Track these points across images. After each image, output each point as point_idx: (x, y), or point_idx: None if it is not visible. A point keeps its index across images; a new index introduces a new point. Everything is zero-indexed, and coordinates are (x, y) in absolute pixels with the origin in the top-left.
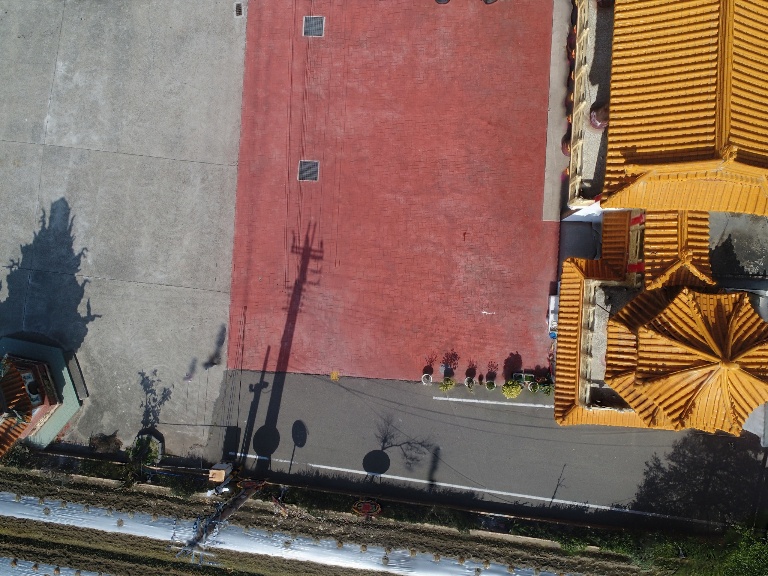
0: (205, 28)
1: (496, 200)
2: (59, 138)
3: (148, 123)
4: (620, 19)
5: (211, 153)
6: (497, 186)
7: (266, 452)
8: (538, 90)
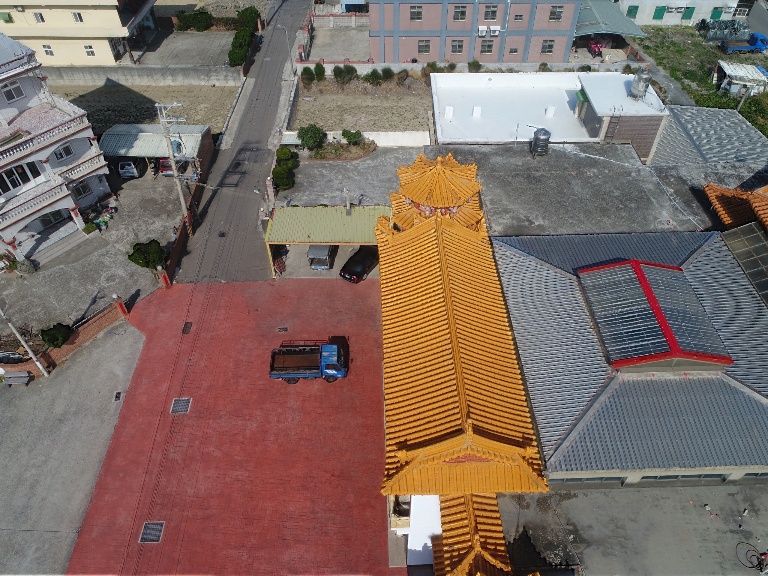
0: (83, 411)
1: (341, 549)
2: None
3: None
4: (387, 353)
5: (55, 521)
6: (342, 534)
7: None
8: (375, 445)
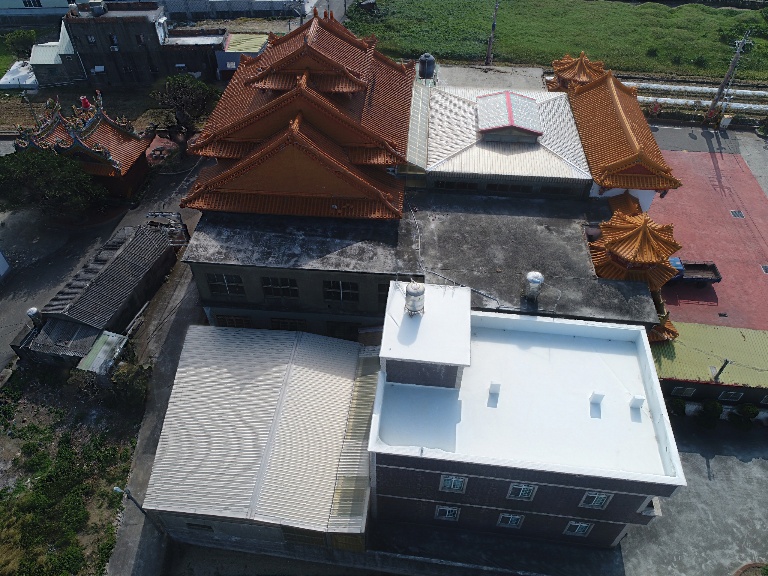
0: None
1: None
2: None
3: None
4: None
5: None
6: None
7: (706, 132)
8: None
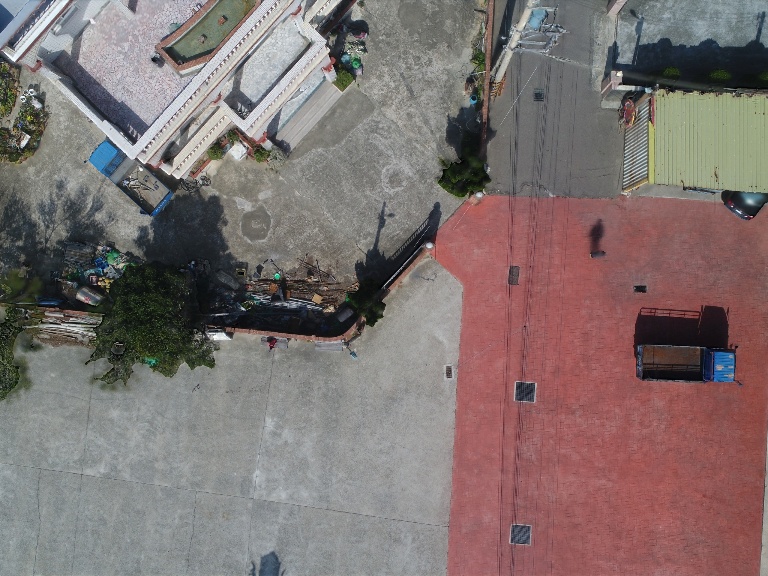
0: (415, 389)
1: (711, 572)
2: (268, 493)
3: (358, 482)
4: None
5: (422, 513)
6: (712, 558)
7: None
8: (754, 465)
